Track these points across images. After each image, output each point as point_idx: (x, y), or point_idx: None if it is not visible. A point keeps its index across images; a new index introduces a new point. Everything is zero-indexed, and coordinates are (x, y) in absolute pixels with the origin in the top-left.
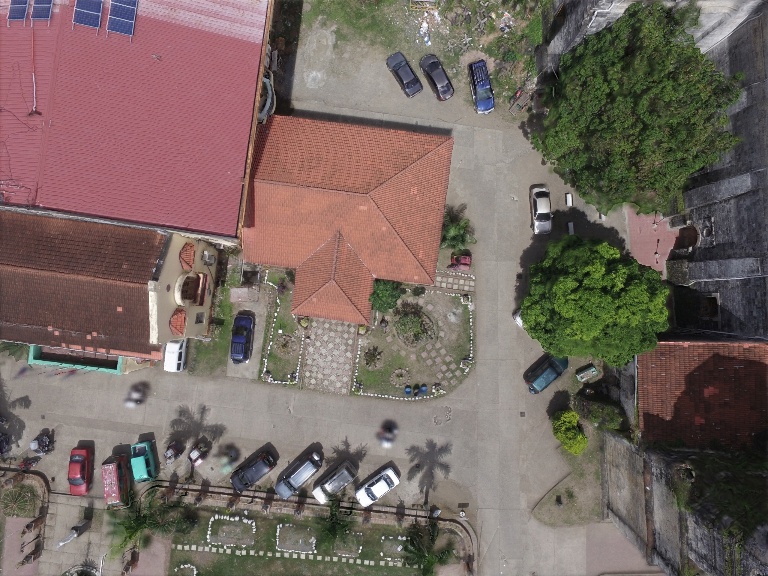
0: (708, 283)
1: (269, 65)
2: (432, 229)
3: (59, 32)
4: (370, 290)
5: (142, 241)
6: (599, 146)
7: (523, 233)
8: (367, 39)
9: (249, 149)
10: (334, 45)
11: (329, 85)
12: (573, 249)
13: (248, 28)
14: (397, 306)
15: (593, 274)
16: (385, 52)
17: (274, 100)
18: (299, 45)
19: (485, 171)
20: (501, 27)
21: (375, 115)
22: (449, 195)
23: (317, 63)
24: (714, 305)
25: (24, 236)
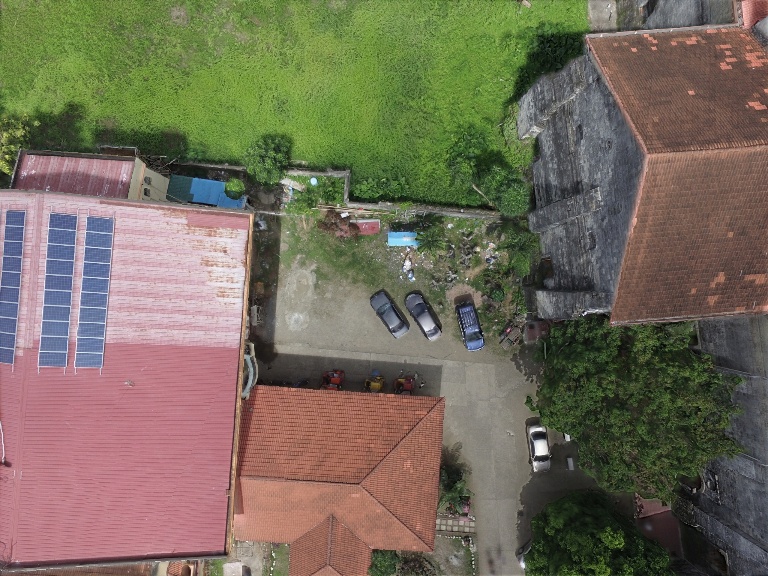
0: (715, 536)
1: (249, 335)
2: (428, 497)
3: (24, 379)
4: (368, 563)
5: (127, 569)
6: (597, 449)
7: (521, 469)
8: (349, 277)
9: (233, 459)
10: (315, 285)
11: (312, 327)
12: (575, 531)
13: (224, 334)
14: (396, 552)
15: (598, 575)
16: (368, 290)
17: (256, 371)
18: (279, 287)
19: (479, 407)
20: (487, 258)
21: (362, 355)
22: (443, 434)
23: (299, 304)
24: (722, 559)
25: (2, 574)
